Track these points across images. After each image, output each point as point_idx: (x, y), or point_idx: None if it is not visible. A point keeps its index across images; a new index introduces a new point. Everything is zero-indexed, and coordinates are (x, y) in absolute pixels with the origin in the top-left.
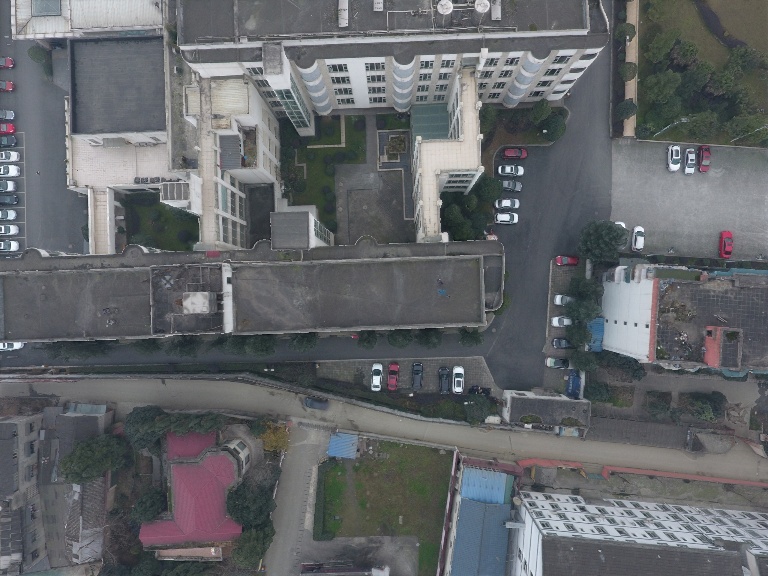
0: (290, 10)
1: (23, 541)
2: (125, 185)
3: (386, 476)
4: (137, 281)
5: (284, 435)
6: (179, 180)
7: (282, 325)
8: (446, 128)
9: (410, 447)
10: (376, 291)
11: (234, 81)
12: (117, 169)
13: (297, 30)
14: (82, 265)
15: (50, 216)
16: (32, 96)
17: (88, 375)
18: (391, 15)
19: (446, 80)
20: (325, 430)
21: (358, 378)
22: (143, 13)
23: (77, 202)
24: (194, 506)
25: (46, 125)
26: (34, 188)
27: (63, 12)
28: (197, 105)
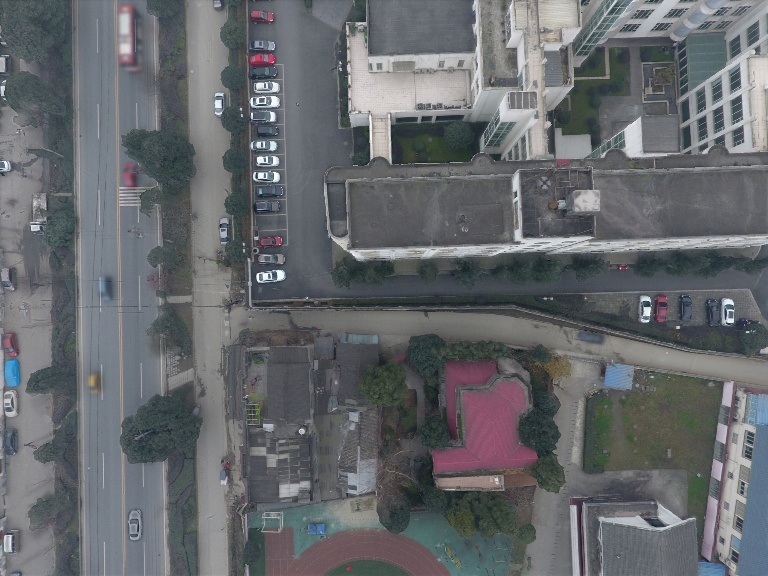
0: None
1: (312, 468)
2: (408, 111)
3: (653, 409)
4: (485, 190)
5: (567, 363)
6: (461, 106)
7: (632, 234)
8: (724, 57)
9: (678, 380)
10: (727, 200)
11: None
12: (396, 96)
13: None
14: (429, 174)
15: (310, 148)
16: (291, 28)
17: None
18: None
19: None
20: (596, 362)
21: (624, 311)
22: None
23: (337, 134)
24: (494, 431)
25: (305, 57)
26: (293, 120)
27: None
28: (524, 19)
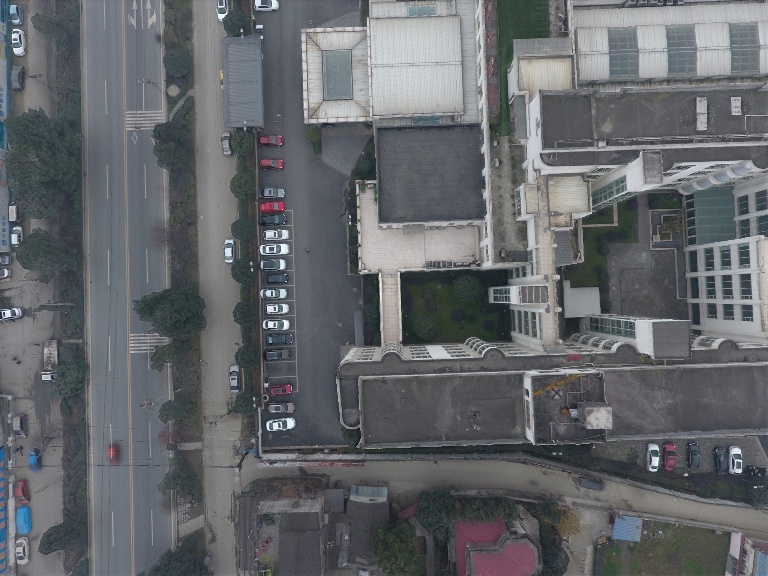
0: (646, 113)
1: None
2: (417, 269)
3: (661, 556)
4: (497, 384)
5: (576, 520)
6: (470, 264)
7: (642, 428)
8: (731, 211)
9: (685, 527)
10: (736, 394)
11: (572, 178)
12: (405, 252)
13: (654, 133)
14: (441, 368)
15: (319, 294)
16: (300, 173)
17: (364, 456)
18: (748, 119)
19: (765, 173)
20: (604, 511)
21: (632, 458)
22: (444, 100)
23: (346, 280)
24: None
25: (314, 203)
26: (303, 266)
27: (355, 96)
28: (535, 202)
